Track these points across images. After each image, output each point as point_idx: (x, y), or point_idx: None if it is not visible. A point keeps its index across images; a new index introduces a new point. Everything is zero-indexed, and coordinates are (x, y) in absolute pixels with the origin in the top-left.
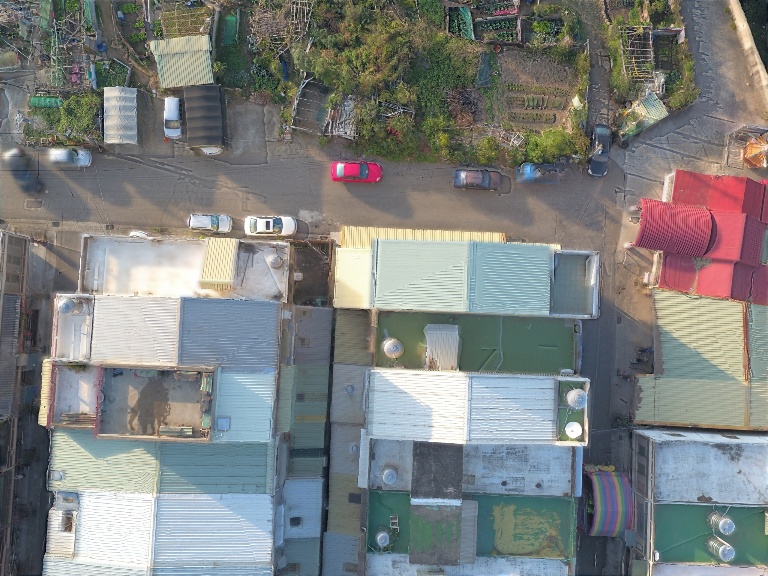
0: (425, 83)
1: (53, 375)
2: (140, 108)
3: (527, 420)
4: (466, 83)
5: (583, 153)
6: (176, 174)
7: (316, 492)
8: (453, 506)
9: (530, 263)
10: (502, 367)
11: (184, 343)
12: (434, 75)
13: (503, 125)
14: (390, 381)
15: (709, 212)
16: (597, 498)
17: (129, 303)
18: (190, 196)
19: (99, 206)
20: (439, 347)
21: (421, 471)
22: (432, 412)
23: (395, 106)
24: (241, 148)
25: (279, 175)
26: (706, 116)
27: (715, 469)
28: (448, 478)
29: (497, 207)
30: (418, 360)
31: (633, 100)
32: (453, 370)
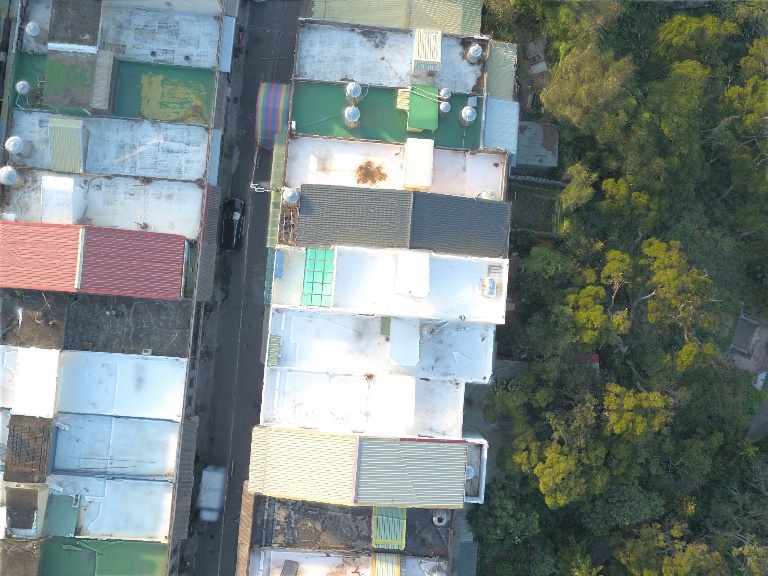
0: None
1: None
2: None
3: None
4: None
5: None
6: None
7: None
8: (89, 53)
9: None
10: None
11: None
12: None
13: None
14: None
15: None
16: (260, 96)
17: None
18: None
19: None
20: None
21: (59, 18)
22: None
23: None
24: None
25: None
26: None
27: (359, 54)
28: (85, 26)
29: None
30: None
31: None
32: None
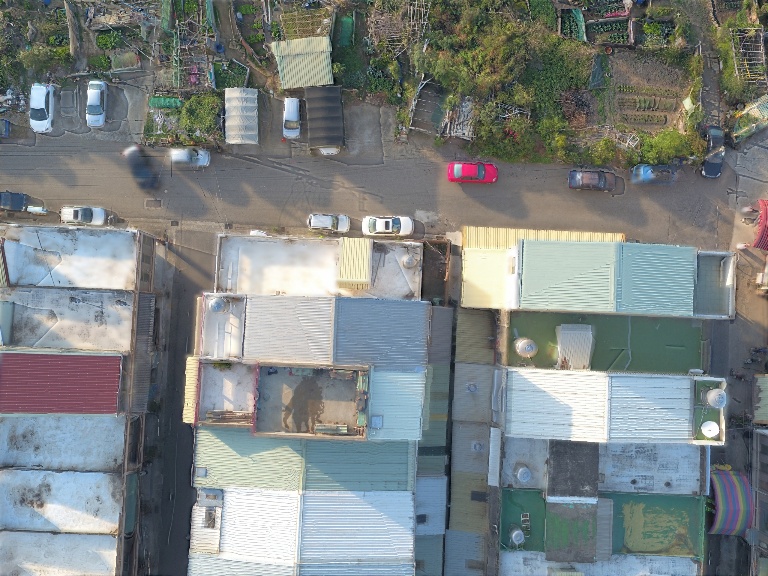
0: (539, 84)
1: (200, 373)
2: (259, 109)
3: (664, 419)
4: (579, 84)
5: (700, 154)
6: (293, 174)
7: (441, 490)
8: (589, 504)
9: (677, 264)
10: (630, 367)
11: (339, 342)
12: (547, 76)
13: (617, 126)
14: (529, 380)
15: None
16: (718, 497)
17: (282, 302)
18: (308, 196)
19: (218, 206)
20: (572, 347)
21: (557, 469)
22: (572, 411)
23: (511, 107)
24: (357, 148)
25: (395, 175)
26: None
27: None
28: (584, 476)
29: (611, 208)
30: (547, 359)
31: (746, 102)
32: (584, 369)
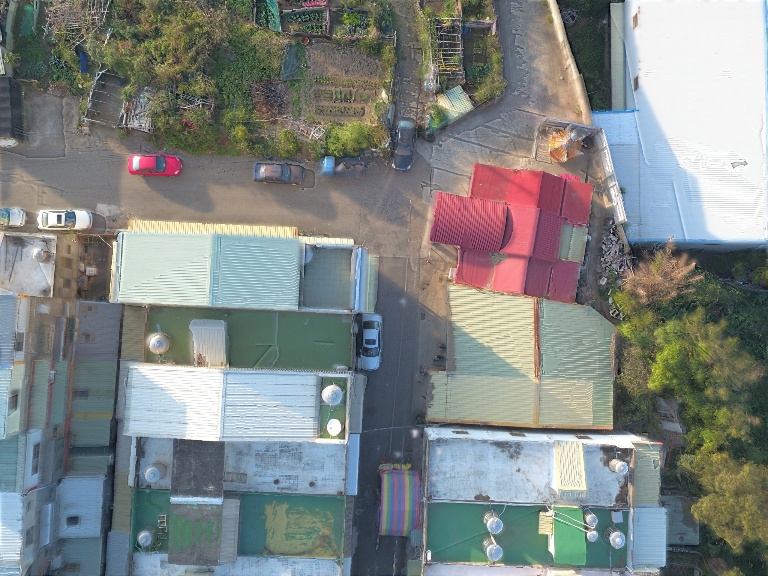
0: (228, 75)
1: None
2: None
3: (287, 417)
4: (272, 75)
5: (382, 146)
6: None
7: (96, 491)
8: (214, 505)
9: (273, 256)
10: (278, 363)
11: None
12: (238, 67)
13: (306, 118)
14: (146, 377)
15: (506, 206)
16: (384, 497)
17: None
18: None
19: None
20: (206, 343)
21: (181, 469)
22: (186, 409)
23: (194, 98)
24: (38, 141)
25: (77, 168)
26: (517, 110)
27: (493, 467)
28: (208, 476)
29: (300, 201)
30: (191, 356)
31: (438, 93)
32: (223, 366)
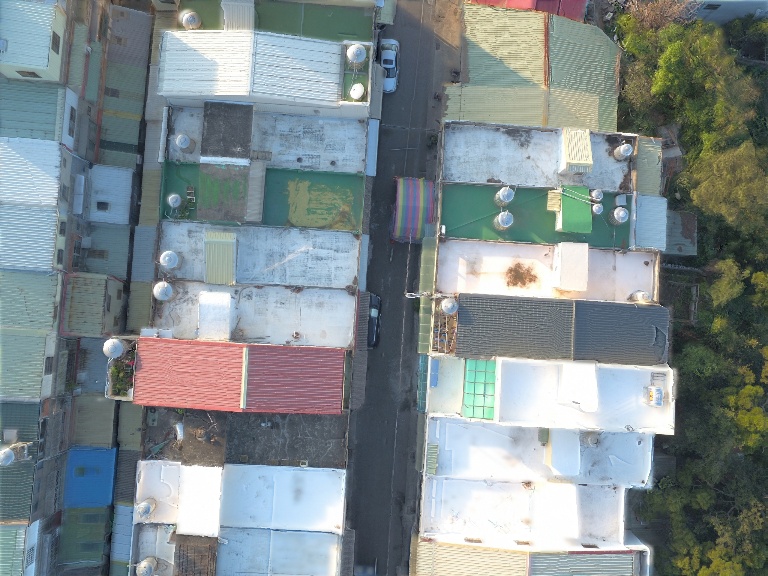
0: None
1: None
2: None
3: (313, 81)
4: None
5: None
6: None
7: (126, 181)
8: (241, 166)
9: None
10: None
11: None
12: None
13: None
14: (180, 40)
15: None
16: (400, 194)
17: None
18: None
19: None
20: (236, 21)
21: (211, 131)
22: (218, 66)
23: None
24: None
25: None
26: None
27: (505, 154)
28: (237, 138)
29: None
30: None
31: None
32: None
